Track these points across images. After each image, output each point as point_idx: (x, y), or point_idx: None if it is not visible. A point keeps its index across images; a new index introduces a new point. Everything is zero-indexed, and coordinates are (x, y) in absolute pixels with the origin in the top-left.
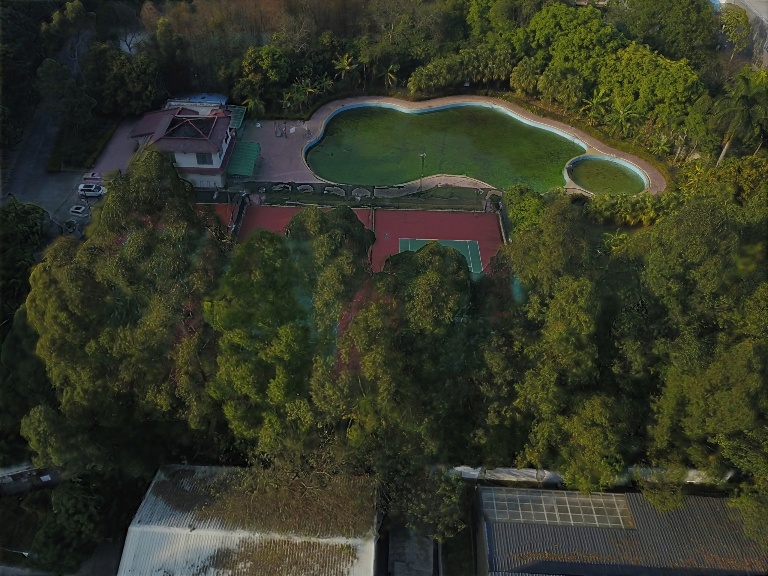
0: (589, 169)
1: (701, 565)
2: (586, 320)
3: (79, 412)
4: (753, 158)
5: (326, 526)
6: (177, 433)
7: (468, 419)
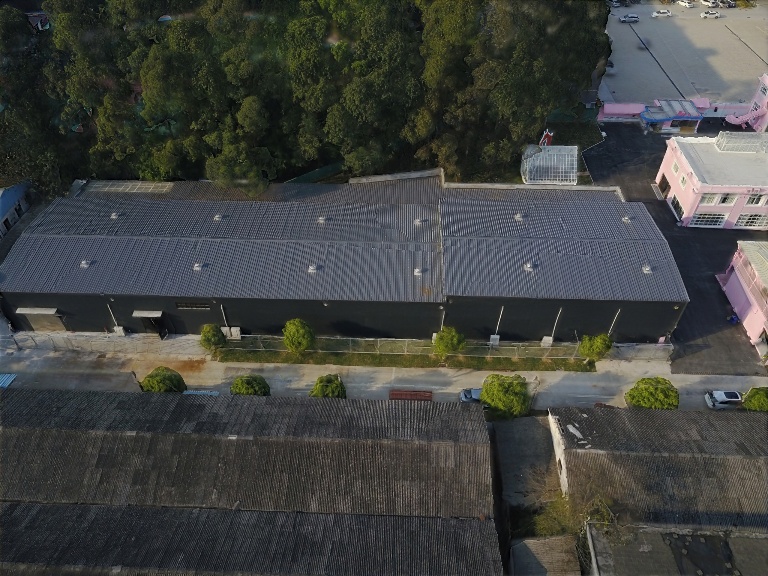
0: None
1: None
2: (67, 34)
3: None
4: None
5: None
6: None
7: None
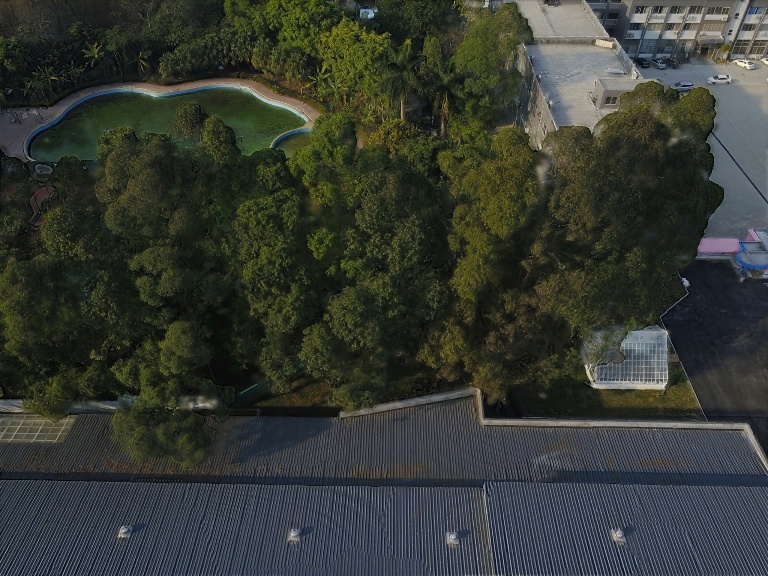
0: (299, 141)
1: (95, 470)
2: None
3: None
4: (398, 121)
5: None
6: None
7: None
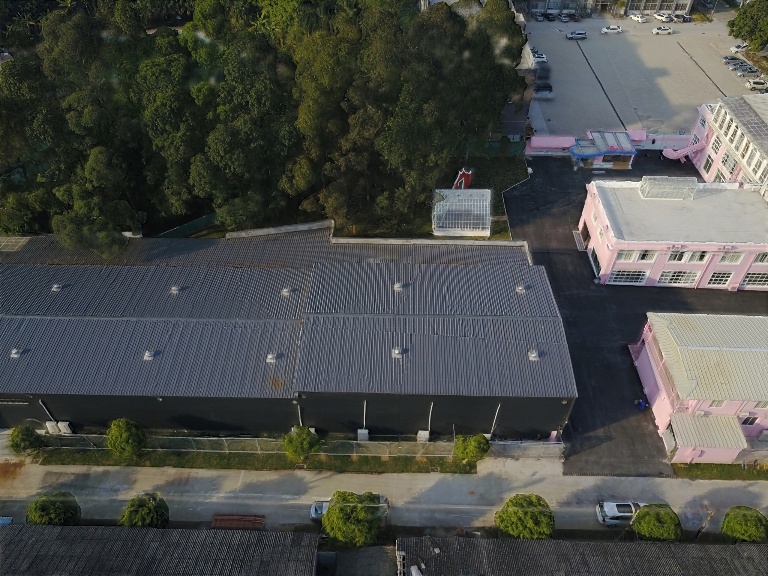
0: None
1: None
2: None
3: None
4: None
5: None
6: None
7: None
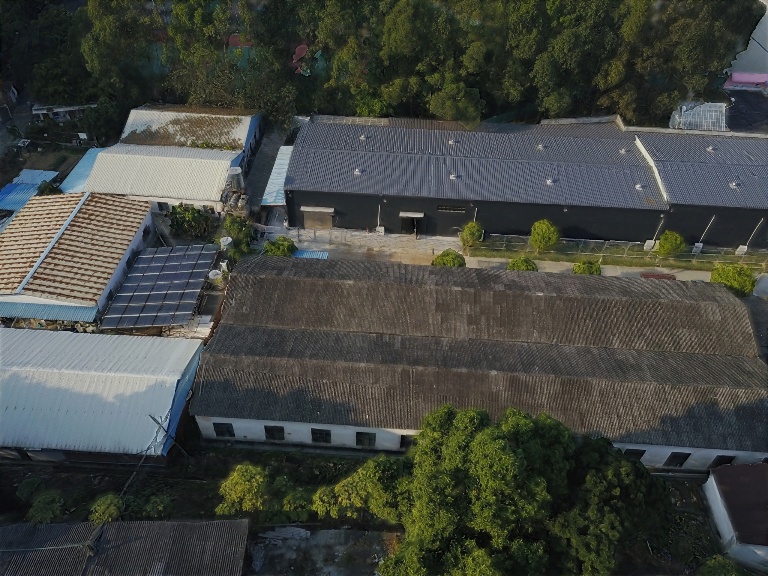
0: None
1: None
2: None
3: (108, 46)
4: None
5: (229, 114)
6: (156, 80)
7: (310, 82)
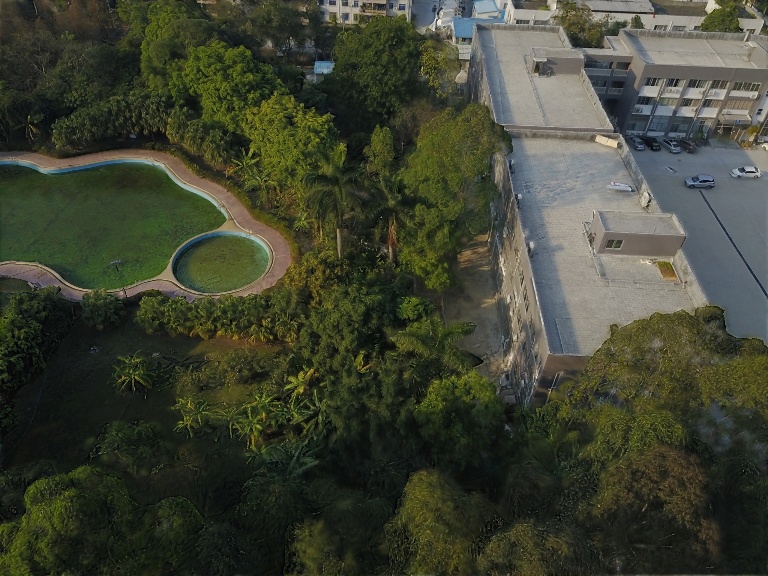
0: (212, 250)
1: None
2: None
3: None
4: (324, 256)
5: None
6: None
7: None
